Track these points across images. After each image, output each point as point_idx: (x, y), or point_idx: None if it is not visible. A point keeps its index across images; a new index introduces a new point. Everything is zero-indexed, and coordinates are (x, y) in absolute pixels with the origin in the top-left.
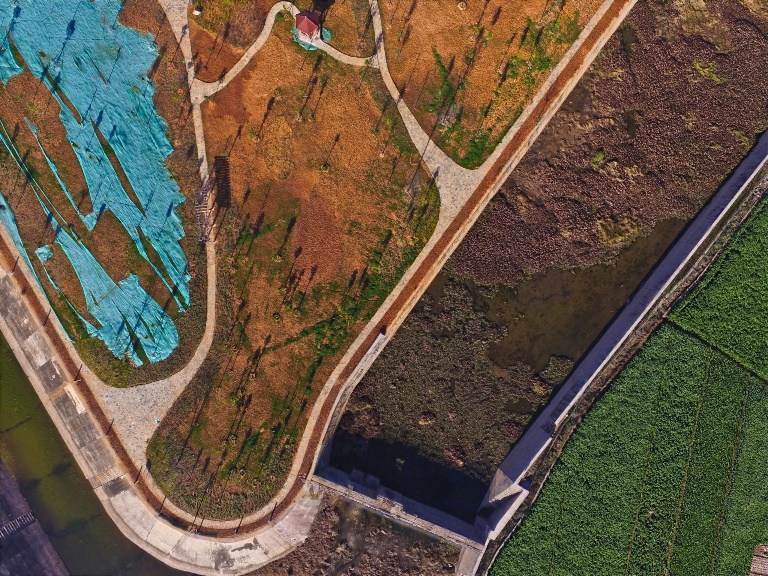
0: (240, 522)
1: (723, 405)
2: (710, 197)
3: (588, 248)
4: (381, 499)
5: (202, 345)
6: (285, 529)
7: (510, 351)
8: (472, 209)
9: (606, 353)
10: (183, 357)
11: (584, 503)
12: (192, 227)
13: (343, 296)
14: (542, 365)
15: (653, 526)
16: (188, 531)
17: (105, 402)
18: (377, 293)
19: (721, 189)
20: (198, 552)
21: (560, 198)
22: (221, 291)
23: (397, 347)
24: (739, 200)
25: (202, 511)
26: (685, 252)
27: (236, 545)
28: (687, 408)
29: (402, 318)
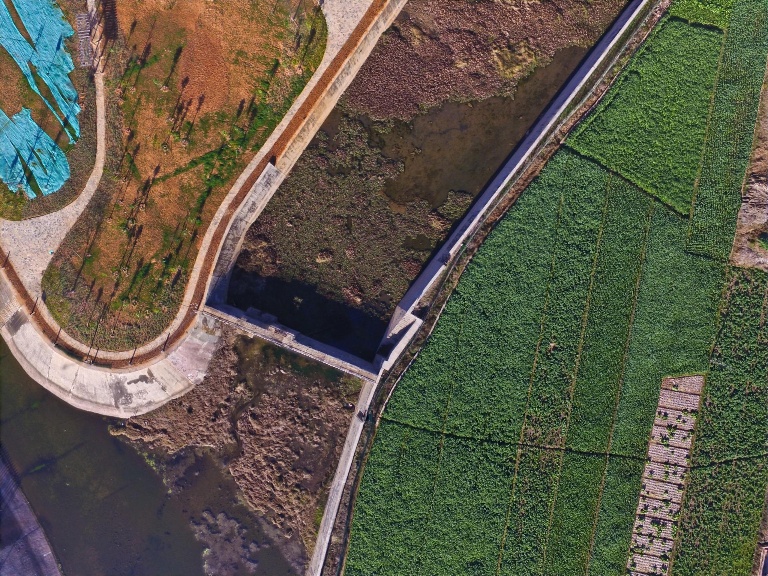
0: (134, 353)
1: (625, 231)
2: (611, 23)
3: (485, 80)
4: (273, 329)
5: (93, 176)
6: (180, 362)
7: (407, 187)
8: (360, 37)
9: (501, 181)
10: (74, 188)
11: (481, 334)
12: (80, 59)
13: (231, 126)
14: (440, 201)
15: (554, 358)
16: (83, 362)
17: (1, 235)
18: (266, 123)
19: (622, 14)
20: (96, 386)
21: (455, 30)
22: (110, 122)
23: (293, 185)
24: (638, 20)
25: (96, 342)
26: (582, 76)
27: (131, 377)
28: (587, 235)
29: (295, 154)
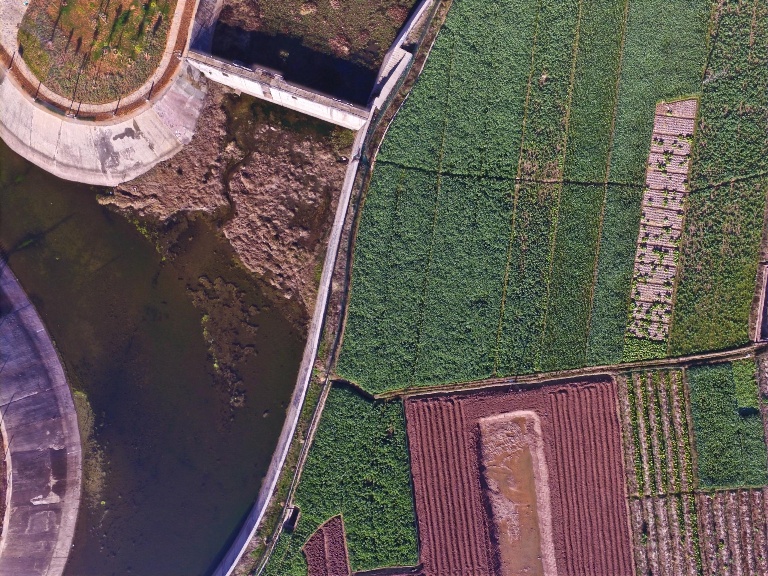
0: (118, 104)
1: None
2: None
3: None
4: (260, 72)
5: None
6: (166, 115)
7: None
8: None
9: None
10: None
11: (472, 67)
12: None
13: None
14: None
15: (547, 88)
16: (66, 116)
17: None
18: None
19: None
20: (81, 146)
21: None
22: None
23: None
24: None
25: (78, 95)
26: None
27: (116, 130)
28: None
29: None
